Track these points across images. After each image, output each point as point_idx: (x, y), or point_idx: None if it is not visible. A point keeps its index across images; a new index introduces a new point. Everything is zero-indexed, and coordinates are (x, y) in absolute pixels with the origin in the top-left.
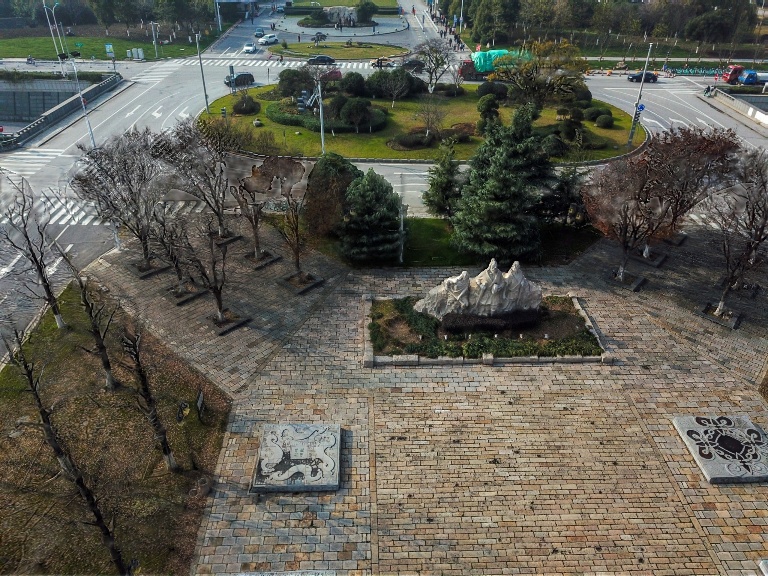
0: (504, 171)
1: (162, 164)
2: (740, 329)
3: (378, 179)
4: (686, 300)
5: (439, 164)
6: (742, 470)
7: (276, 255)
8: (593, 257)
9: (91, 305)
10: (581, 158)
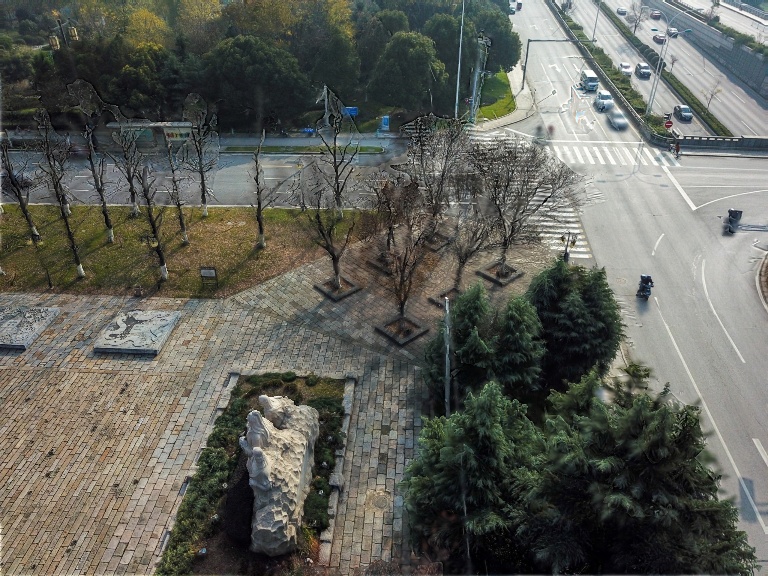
0: (463, 415)
1: None
2: None
3: (508, 311)
4: None
5: None
6: None
7: None
8: None
9: (259, 183)
10: None
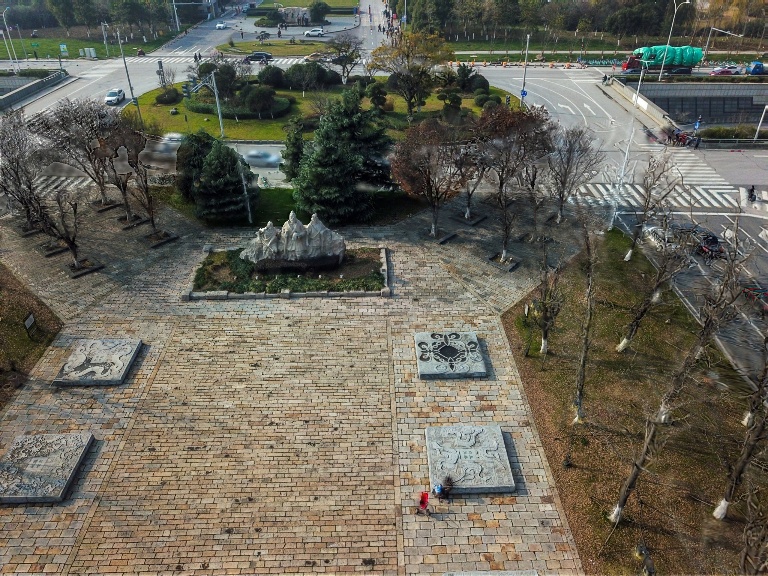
0: (325, 141)
1: (42, 140)
2: (515, 272)
3: (228, 151)
4: (482, 251)
5: (288, 139)
6: (447, 369)
7: (145, 218)
8: (420, 218)
9: None
10: (453, 138)
